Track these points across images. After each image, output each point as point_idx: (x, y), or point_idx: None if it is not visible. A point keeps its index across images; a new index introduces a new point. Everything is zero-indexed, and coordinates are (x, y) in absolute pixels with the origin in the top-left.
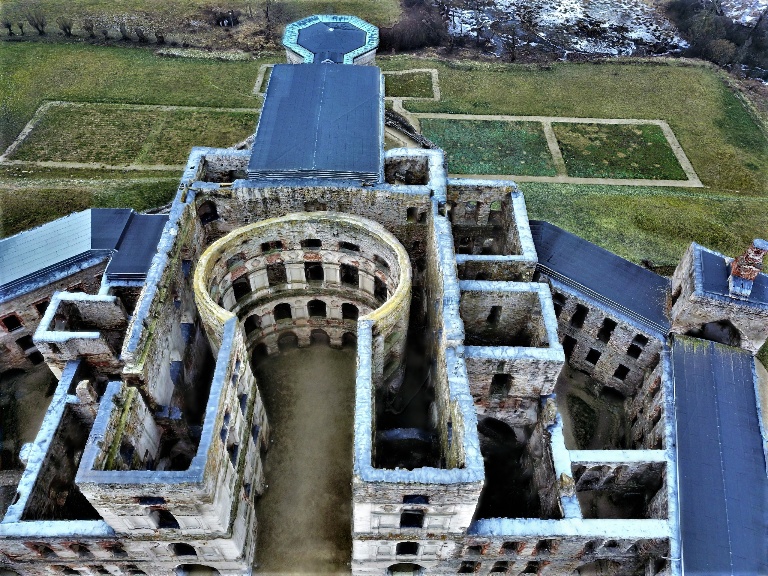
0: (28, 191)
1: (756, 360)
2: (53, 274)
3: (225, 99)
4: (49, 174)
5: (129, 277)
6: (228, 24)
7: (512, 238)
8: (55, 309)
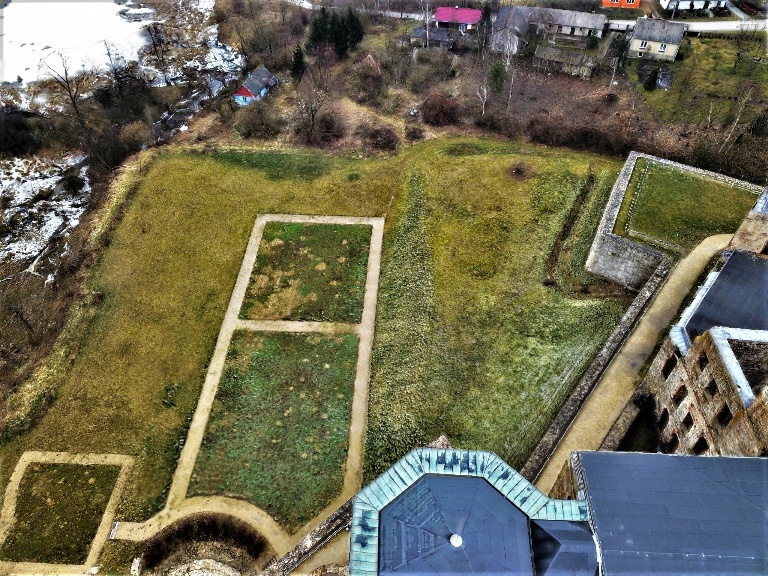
0: None
1: (717, 236)
2: None
3: None
4: None
5: None
6: None
7: (761, 357)
8: None
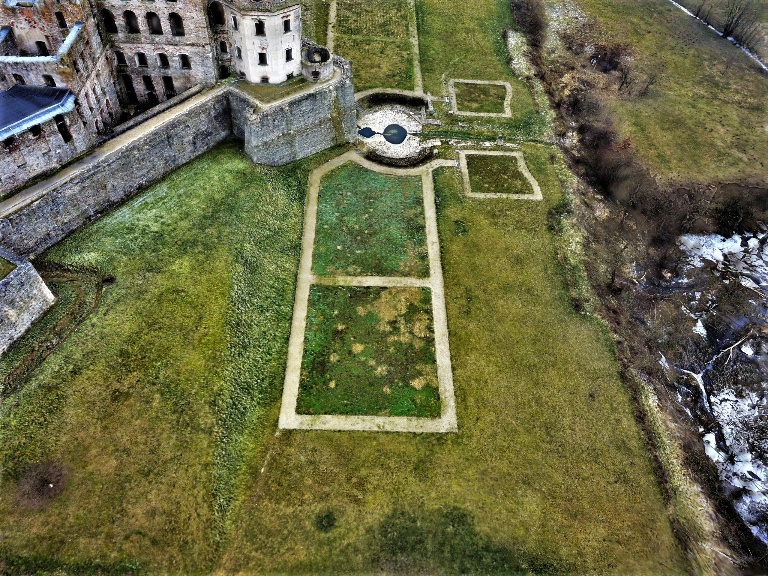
0: None
1: None
2: None
3: (433, 64)
4: (321, 6)
5: None
6: None
7: None
8: None
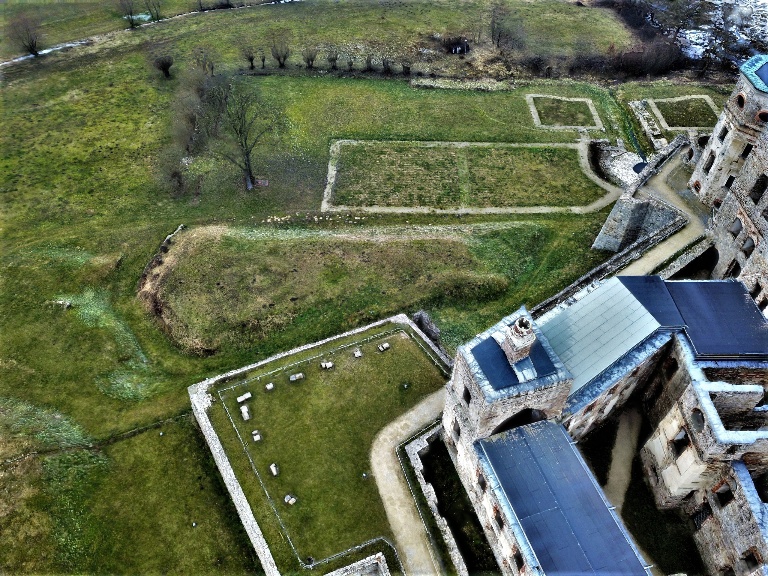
0: (399, 242)
1: None
2: (633, 355)
3: (514, 133)
4: (384, 220)
5: (720, 357)
6: (460, 51)
7: None
8: (712, 403)
